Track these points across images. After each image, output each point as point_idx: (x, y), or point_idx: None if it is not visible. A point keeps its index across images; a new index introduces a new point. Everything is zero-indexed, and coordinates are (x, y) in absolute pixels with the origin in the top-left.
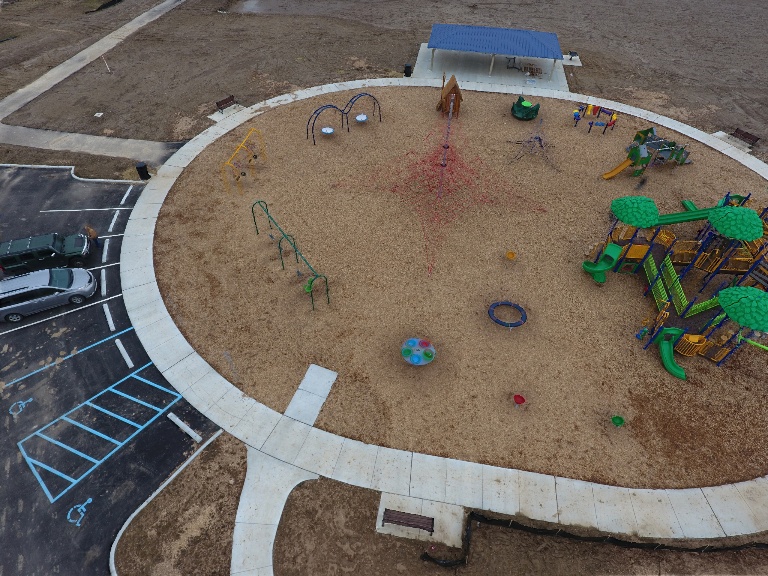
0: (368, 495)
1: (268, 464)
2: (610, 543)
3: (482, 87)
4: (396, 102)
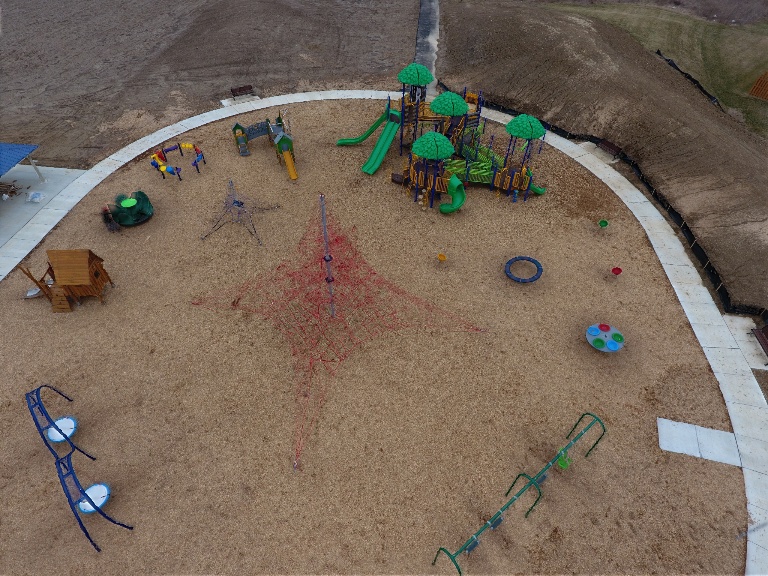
0: (761, 378)
1: None
2: None
3: (17, 250)
4: (4, 374)
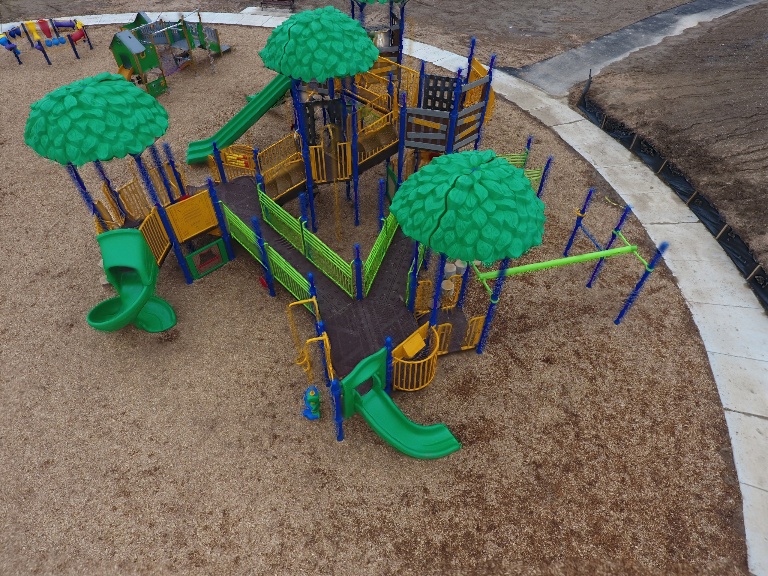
0: None
1: None
2: None
3: None
4: None
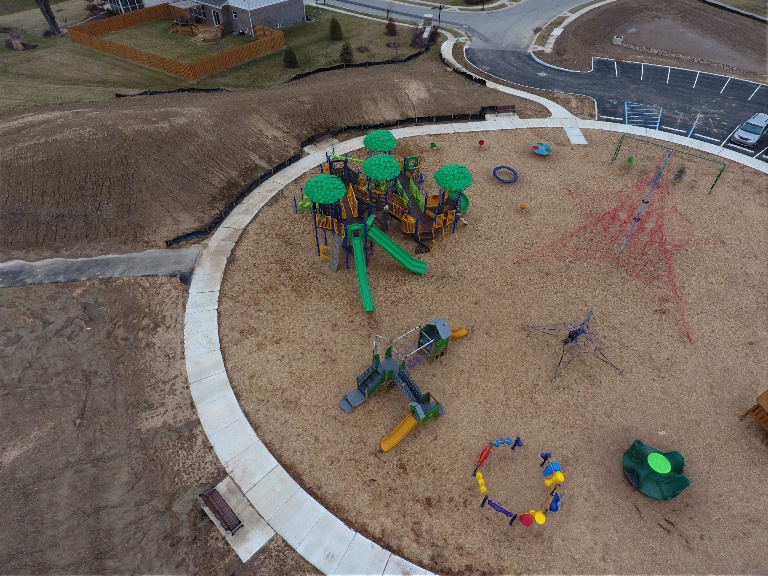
0: None
1: (568, 117)
2: (432, 121)
3: None
4: None
